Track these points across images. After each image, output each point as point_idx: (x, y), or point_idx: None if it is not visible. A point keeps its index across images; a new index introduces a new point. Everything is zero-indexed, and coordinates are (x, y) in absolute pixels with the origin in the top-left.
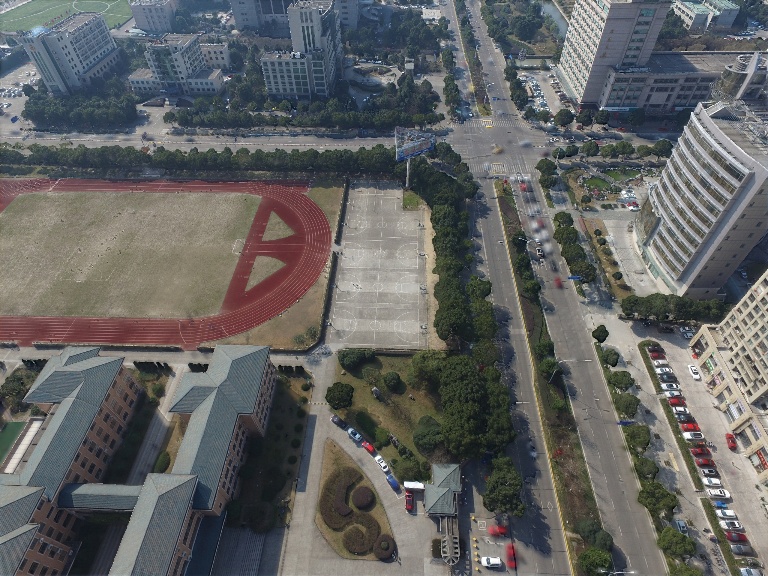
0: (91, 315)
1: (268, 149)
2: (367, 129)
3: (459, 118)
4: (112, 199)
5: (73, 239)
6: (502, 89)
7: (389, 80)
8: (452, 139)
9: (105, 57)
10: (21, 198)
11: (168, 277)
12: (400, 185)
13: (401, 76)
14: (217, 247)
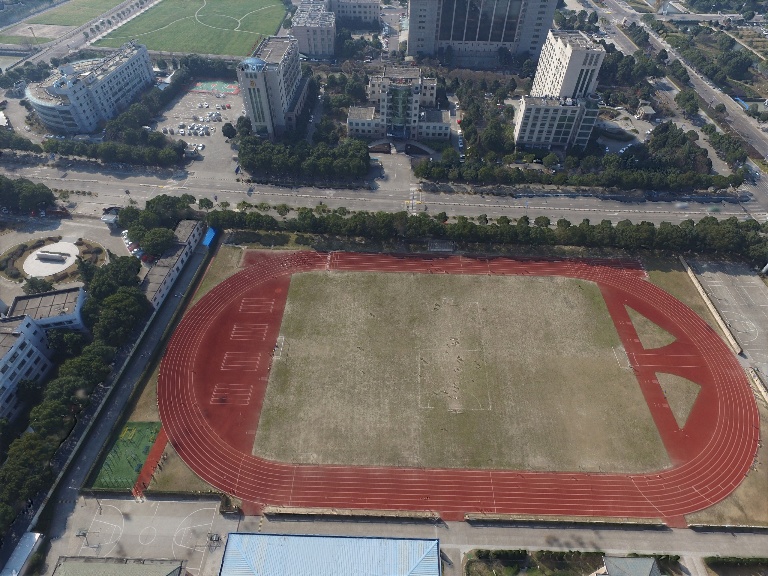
0: (507, 467)
1: (555, 215)
2: (659, 191)
3: (747, 178)
4: (414, 283)
5: (405, 343)
6: (763, 140)
7: (628, 125)
8: (760, 206)
9: (300, 90)
10: (298, 280)
11: (566, 405)
12: (751, 269)
13: (662, 125)
14: (596, 358)
